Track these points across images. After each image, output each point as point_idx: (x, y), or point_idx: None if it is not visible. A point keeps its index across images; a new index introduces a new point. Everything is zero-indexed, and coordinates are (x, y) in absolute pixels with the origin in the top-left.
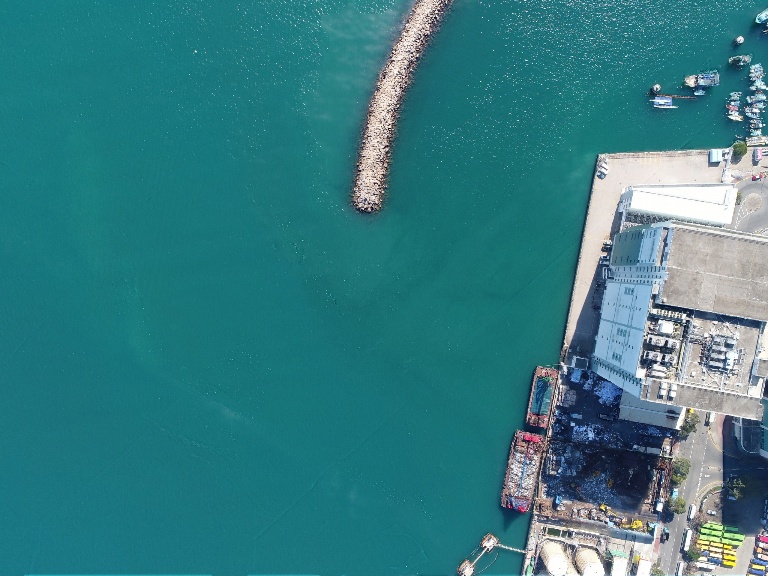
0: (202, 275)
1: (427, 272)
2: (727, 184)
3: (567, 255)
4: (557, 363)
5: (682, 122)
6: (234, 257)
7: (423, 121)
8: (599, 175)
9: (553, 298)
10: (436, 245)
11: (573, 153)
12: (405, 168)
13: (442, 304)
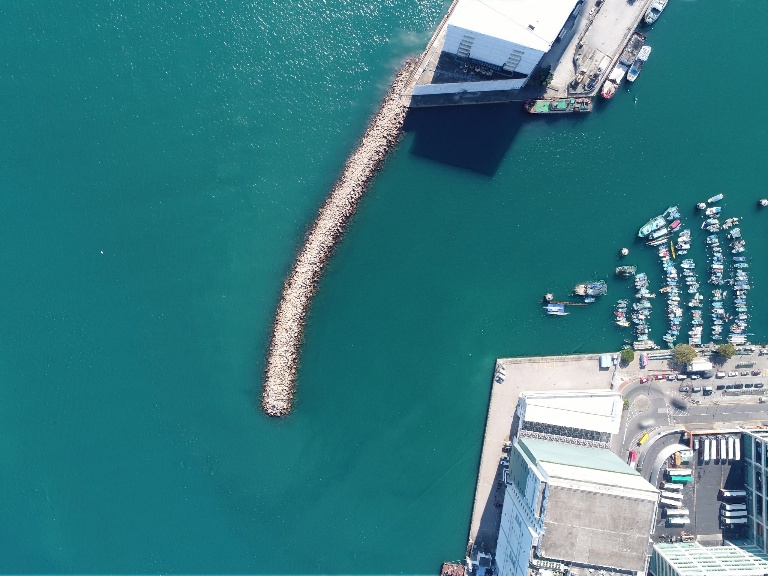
0: (110, 496)
1: (336, 473)
2: (614, 395)
3: (470, 454)
4: (463, 558)
5: (574, 327)
6: (141, 478)
7: (329, 326)
8: (497, 380)
9: (458, 495)
10: (345, 445)
11: (473, 357)
12: (313, 372)
13: (352, 504)
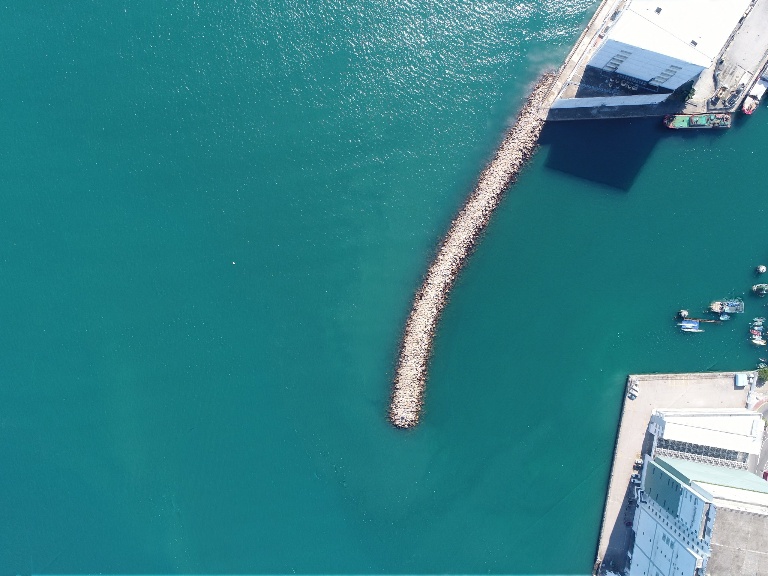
0: (244, 505)
1: (463, 487)
2: (754, 414)
3: (599, 471)
4: None
5: (708, 345)
6: (276, 487)
7: (458, 338)
8: (630, 397)
9: (586, 512)
10: (471, 459)
11: (604, 373)
12: (441, 384)
13: (478, 518)
